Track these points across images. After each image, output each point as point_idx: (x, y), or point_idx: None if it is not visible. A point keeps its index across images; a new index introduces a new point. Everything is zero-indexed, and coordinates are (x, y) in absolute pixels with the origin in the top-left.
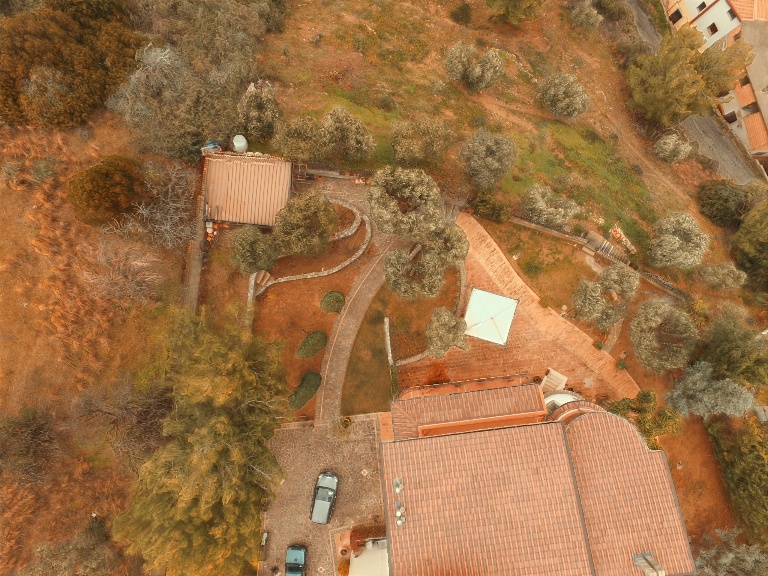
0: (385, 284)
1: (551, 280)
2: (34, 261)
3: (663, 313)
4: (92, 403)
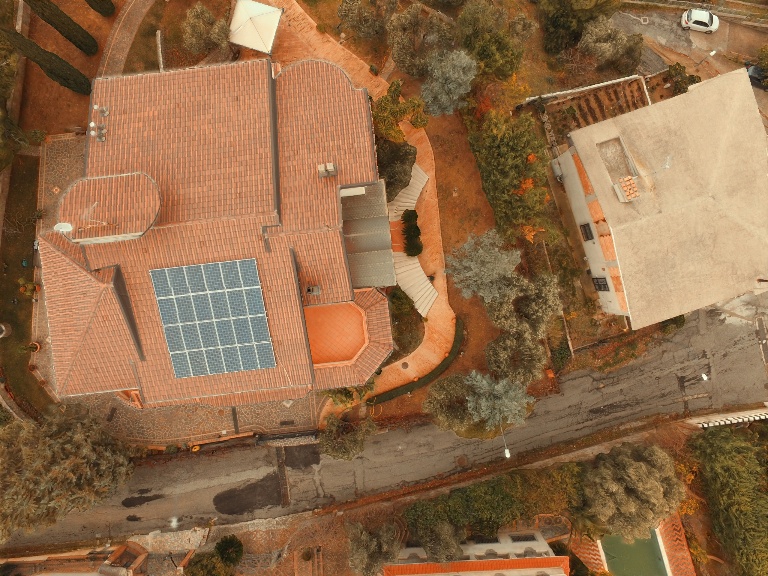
0: None
1: (330, 8)
2: None
3: (417, 16)
4: None
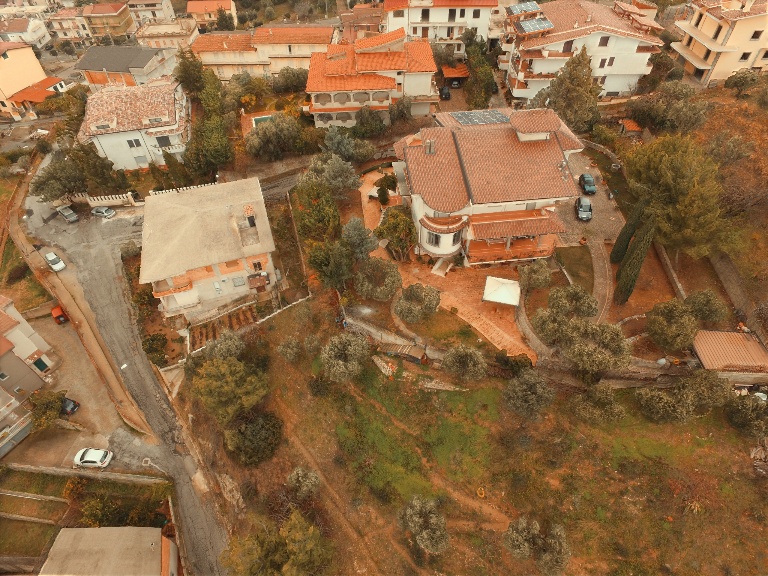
0: None
1: (449, 327)
2: None
3: None
4: (762, 227)
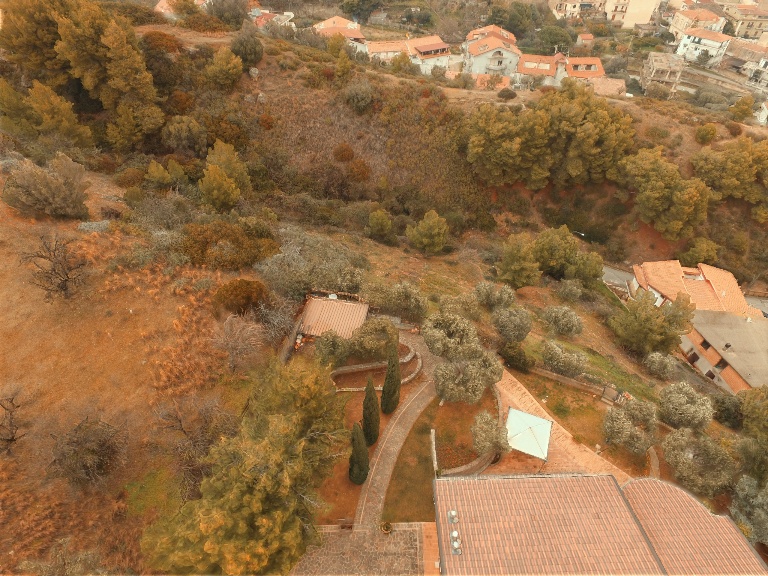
0: (432, 403)
1: (580, 422)
2: (165, 337)
3: (689, 438)
4: (157, 447)
